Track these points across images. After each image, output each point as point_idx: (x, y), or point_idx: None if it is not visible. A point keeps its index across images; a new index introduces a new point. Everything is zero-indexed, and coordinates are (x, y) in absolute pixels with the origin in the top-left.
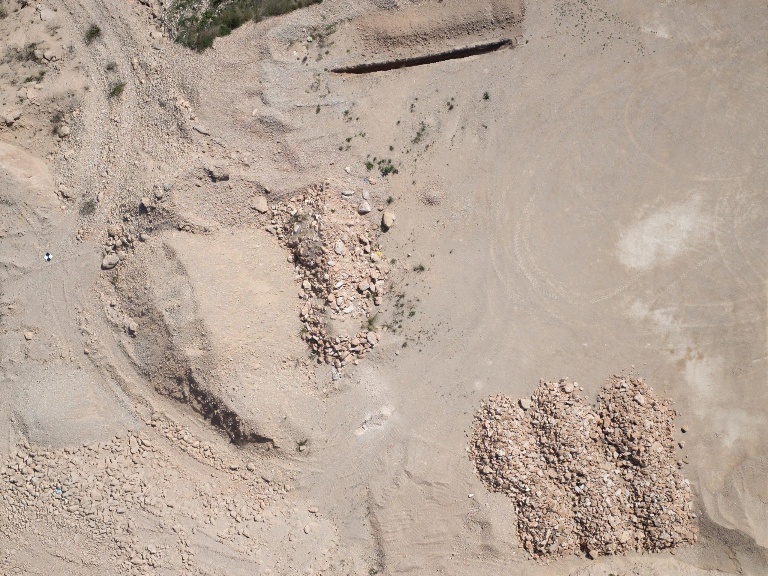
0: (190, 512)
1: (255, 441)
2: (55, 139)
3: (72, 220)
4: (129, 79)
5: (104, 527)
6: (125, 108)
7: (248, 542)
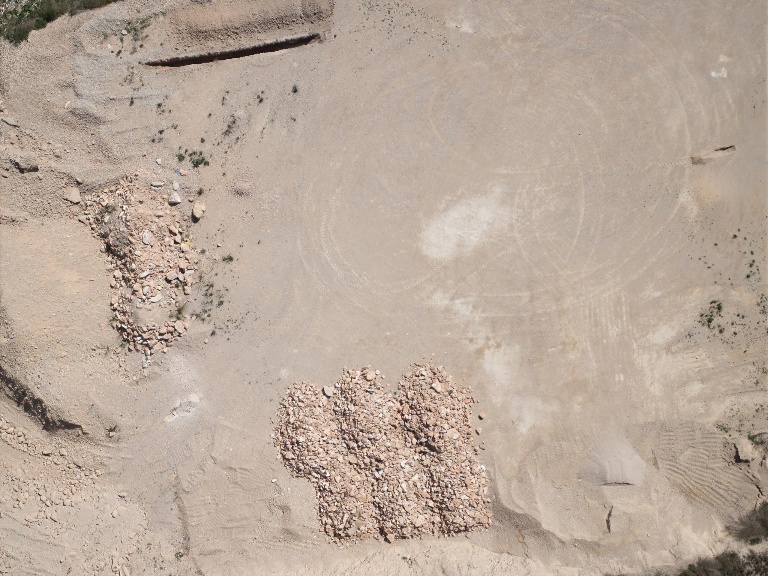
0: None
1: (65, 427)
2: None
3: None
4: None
5: None
6: None
7: (55, 526)
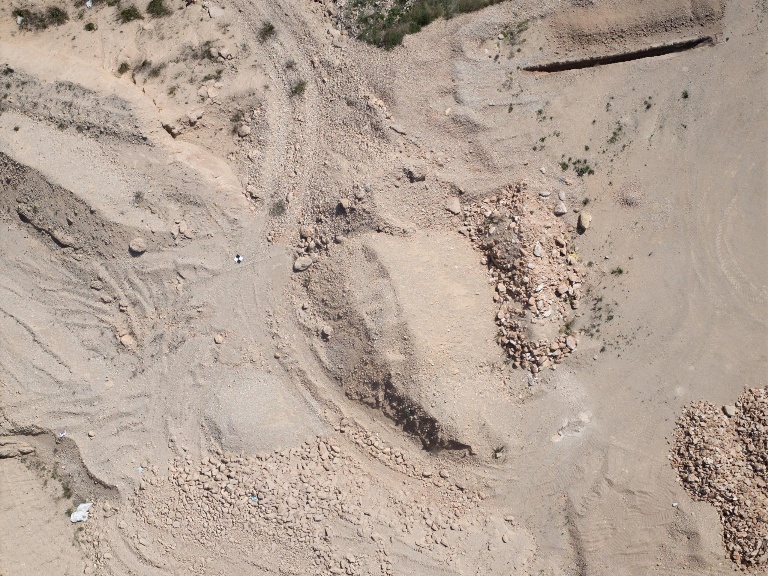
0: (387, 520)
1: (451, 448)
2: (235, 139)
3: (262, 221)
4: (309, 77)
5: (303, 535)
6: (308, 107)
7: (447, 551)
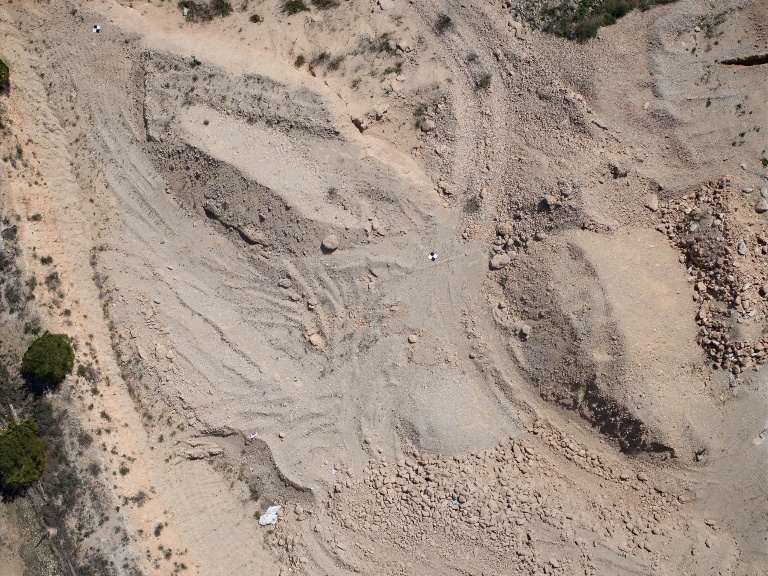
0: (590, 524)
1: (652, 450)
2: (418, 133)
3: (456, 218)
4: (493, 71)
5: (507, 540)
6: (495, 101)
7: (650, 556)
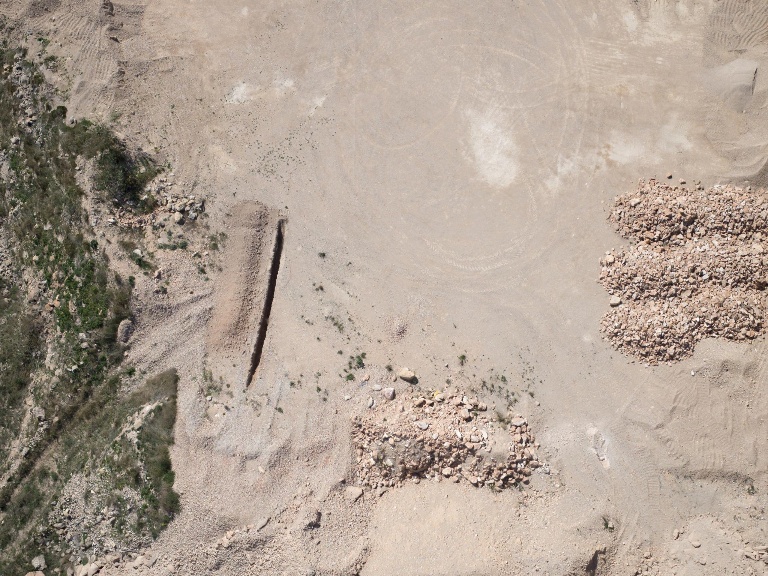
0: None
1: (593, 571)
2: None
3: None
4: None
5: None
6: None
7: None
